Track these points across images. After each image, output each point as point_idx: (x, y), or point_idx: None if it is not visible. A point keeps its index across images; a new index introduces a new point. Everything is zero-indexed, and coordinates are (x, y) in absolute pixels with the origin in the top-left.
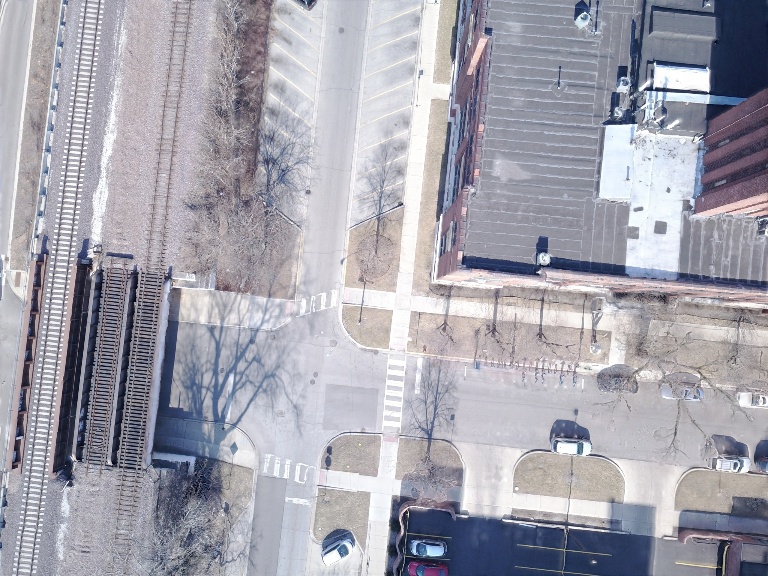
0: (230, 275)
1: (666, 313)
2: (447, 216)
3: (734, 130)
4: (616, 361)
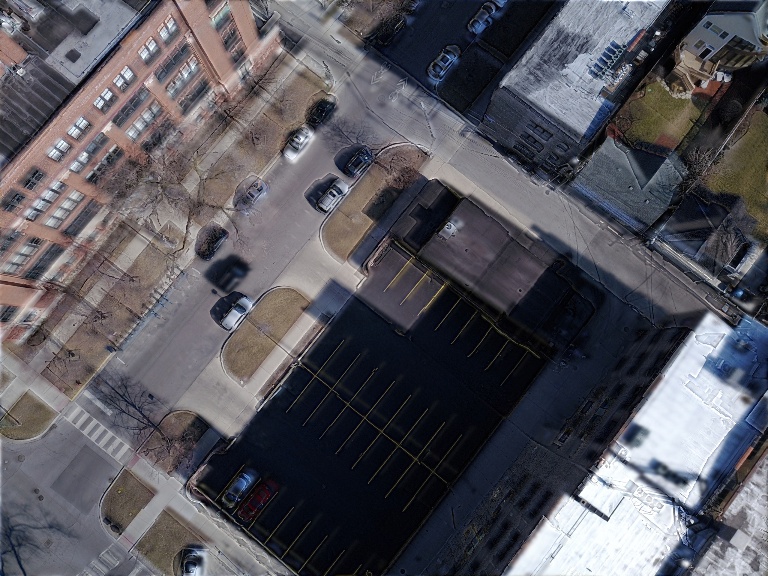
0: None
1: (183, 167)
2: None
3: None
4: (195, 232)
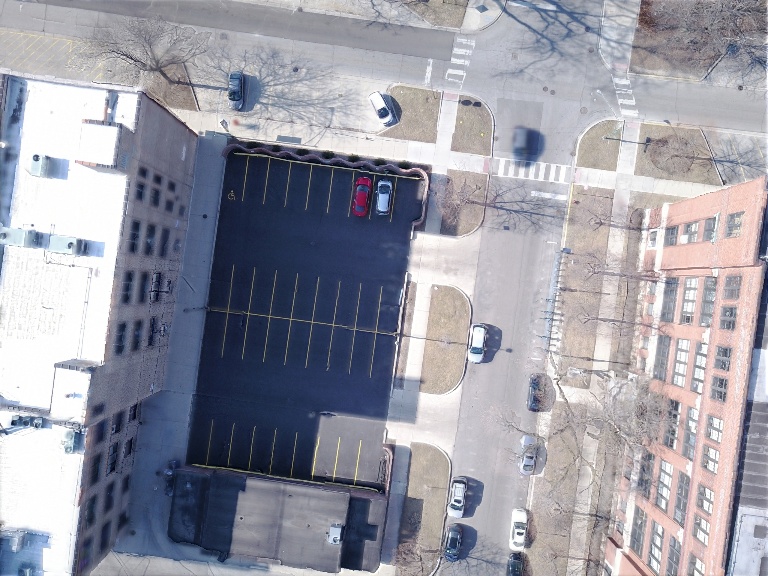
0: (658, 7)
1: None
2: None
3: None
4: None
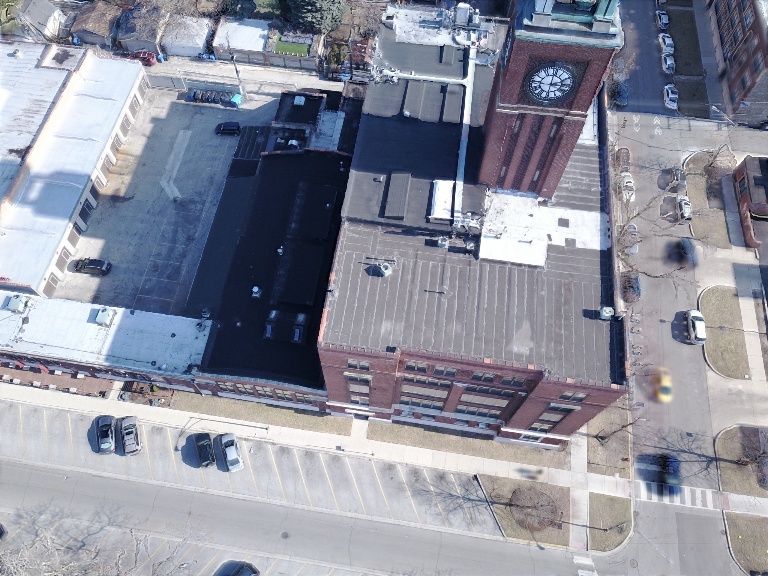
0: None
1: None
2: (522, 417)
3: (501, 162)
4: None
